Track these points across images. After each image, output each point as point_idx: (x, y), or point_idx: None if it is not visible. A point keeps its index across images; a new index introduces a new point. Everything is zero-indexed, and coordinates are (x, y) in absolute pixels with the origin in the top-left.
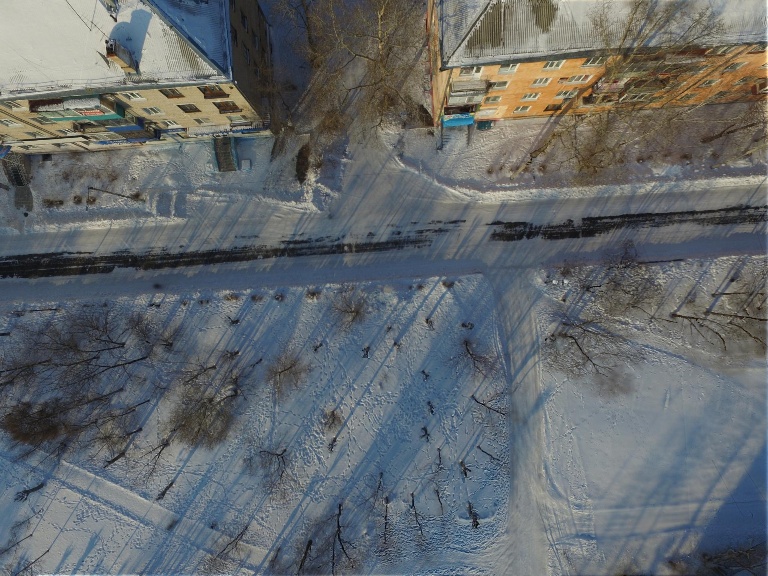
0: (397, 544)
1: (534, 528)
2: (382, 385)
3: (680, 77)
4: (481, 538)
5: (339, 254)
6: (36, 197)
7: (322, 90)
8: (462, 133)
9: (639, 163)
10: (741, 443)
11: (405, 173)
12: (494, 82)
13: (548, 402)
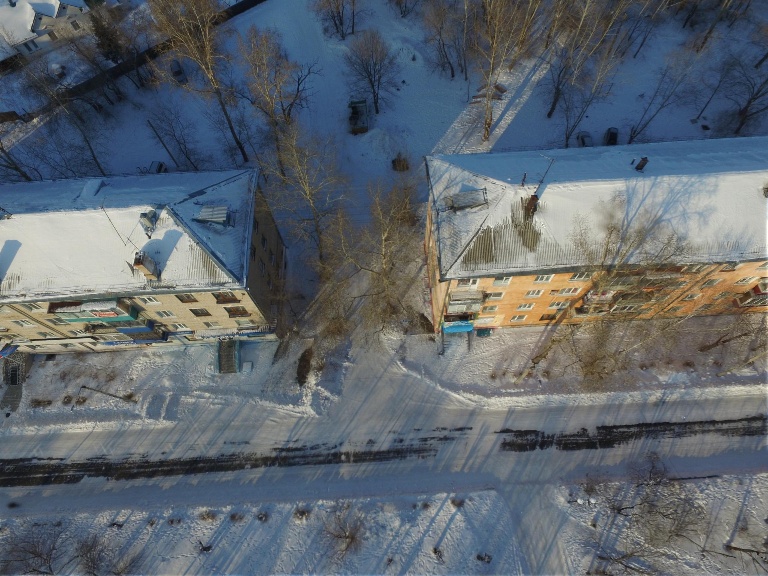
0: None
1: None
2: None
3: (663, 291)
4: None
5: (335, 464)
6: (25, 397)
7: (329, 300)
8: (462, 339)
9: (643, 370)
10: None
11: (407, 377)
12: (490, 293)
13: None
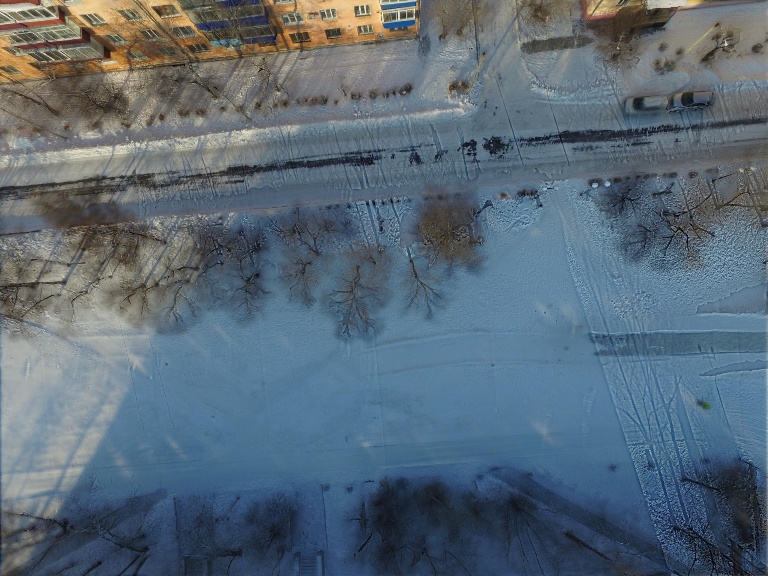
0: None
1: None
2: None
3: None
4: None
5: None
6: None
7: None
8: None
9: None
10: (98, 409)
11: None
12: None
13: None
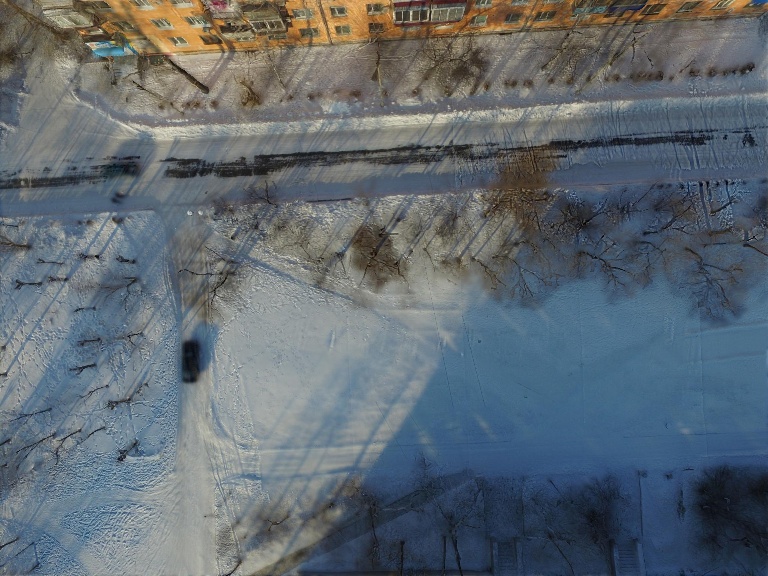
0: (66, 480)
1: (202, 467)
2: (53, 320)
3: (293, 2)
4: (149, 476)
5: (16, 189)
6: None
7: None
8: (131, 67)
9: (310, 100)
10: (405, 385)
11: (81, 108)
12: (88, 1)
13: (216, 341)
